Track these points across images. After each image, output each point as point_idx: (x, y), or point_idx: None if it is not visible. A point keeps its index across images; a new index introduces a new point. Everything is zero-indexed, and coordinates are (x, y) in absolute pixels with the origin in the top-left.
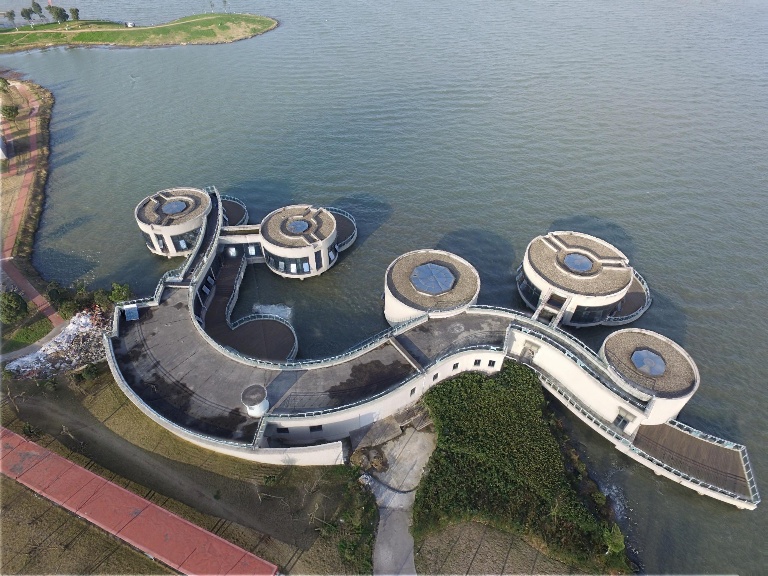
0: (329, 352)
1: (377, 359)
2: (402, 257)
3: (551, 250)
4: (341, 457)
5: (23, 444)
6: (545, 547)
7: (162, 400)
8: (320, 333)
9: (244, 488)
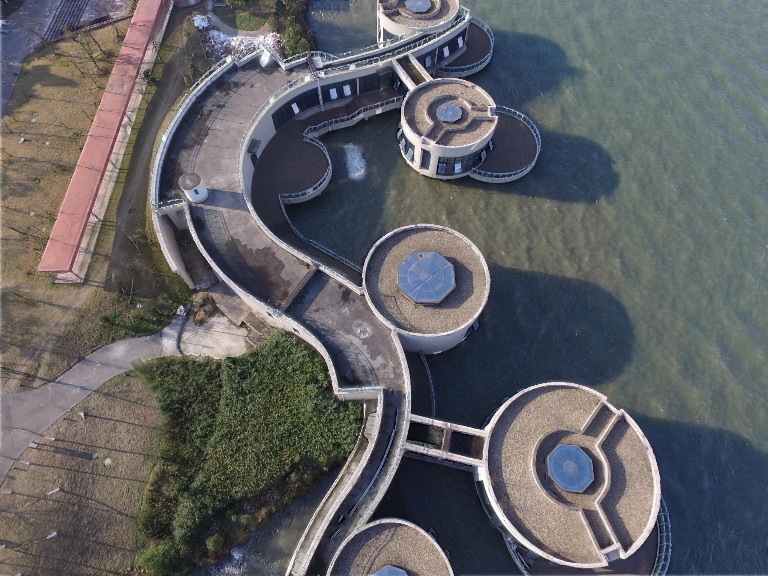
0: (321, 229)
1: (285, 265)
2: (453, 232)
3: (583, 421)
4: (185, 281)
5: (130, 78)
6: (147, 487)
7: (188, 129)
8: (343, 212)
9: (140, 224)
